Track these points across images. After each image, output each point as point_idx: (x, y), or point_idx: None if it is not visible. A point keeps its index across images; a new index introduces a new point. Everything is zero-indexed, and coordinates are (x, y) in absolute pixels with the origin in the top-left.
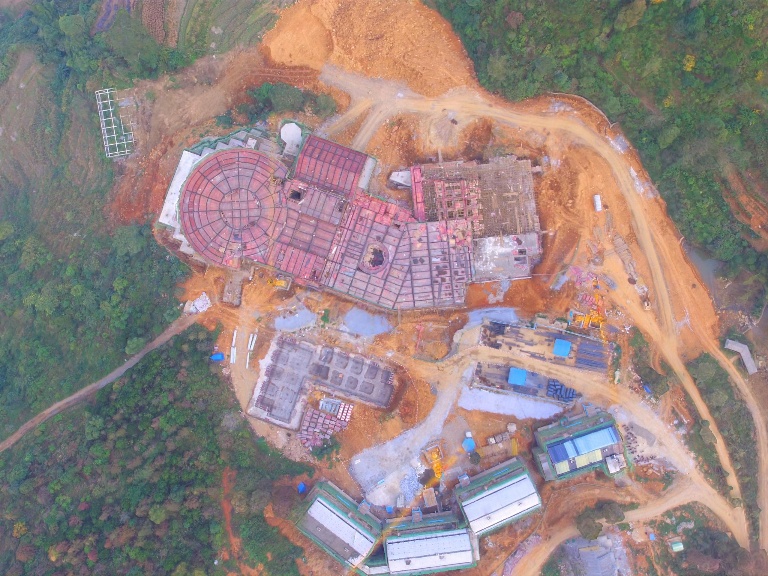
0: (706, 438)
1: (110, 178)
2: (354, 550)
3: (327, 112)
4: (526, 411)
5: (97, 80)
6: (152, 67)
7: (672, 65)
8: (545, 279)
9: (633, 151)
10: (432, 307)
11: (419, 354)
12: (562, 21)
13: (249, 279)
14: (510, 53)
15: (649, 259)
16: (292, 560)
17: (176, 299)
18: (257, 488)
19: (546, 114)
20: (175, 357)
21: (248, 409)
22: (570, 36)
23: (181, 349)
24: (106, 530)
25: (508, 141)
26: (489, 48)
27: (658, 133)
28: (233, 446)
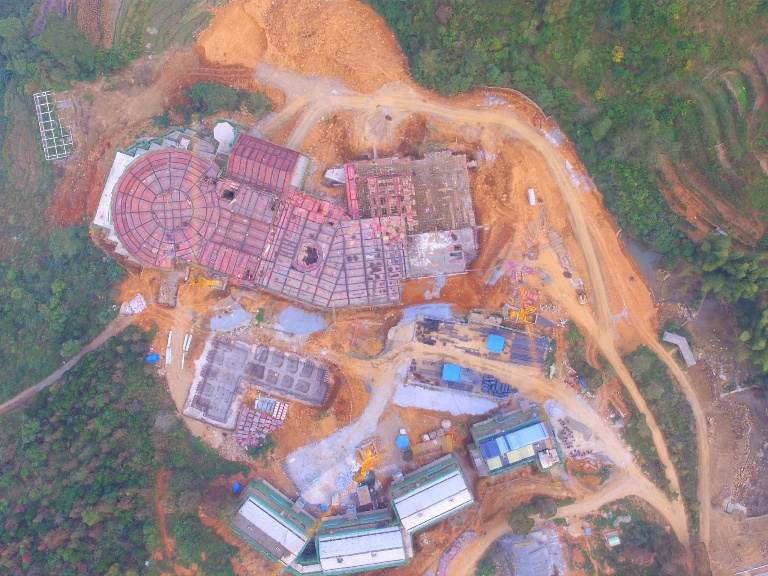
0: (641, 431)
1: (51, 181)
2: (286, 549)
3: (260, 111)
4: (461, 407)
5: (35, 83)
6: (89, 69)
7: (602, 56)
8: (481, 274)
9: (569, 144)
10: (367, 304)
11: (354, 352)
12: (491, 14)
13: (185, 279)
14: (442, 48)
15: (586, 252)
16: (227, 560)
17: (113, 301)
18: (188, 488)
19: (480, 108)
20: (111, 359)
21: (184, 409)
22: (500, 29)
23: (116, 351)
24: (40, 532)
25: (443, 136)
26: (422, 43)
27: (592, 125)
28: (167, 447)
